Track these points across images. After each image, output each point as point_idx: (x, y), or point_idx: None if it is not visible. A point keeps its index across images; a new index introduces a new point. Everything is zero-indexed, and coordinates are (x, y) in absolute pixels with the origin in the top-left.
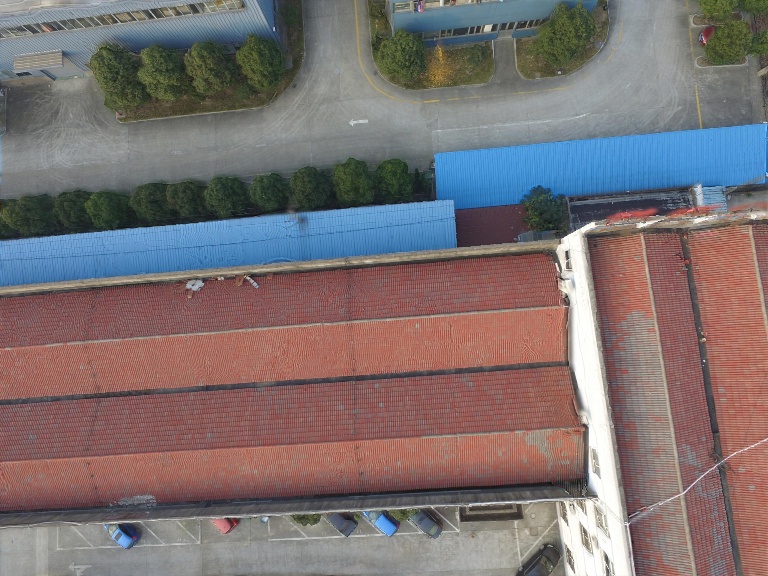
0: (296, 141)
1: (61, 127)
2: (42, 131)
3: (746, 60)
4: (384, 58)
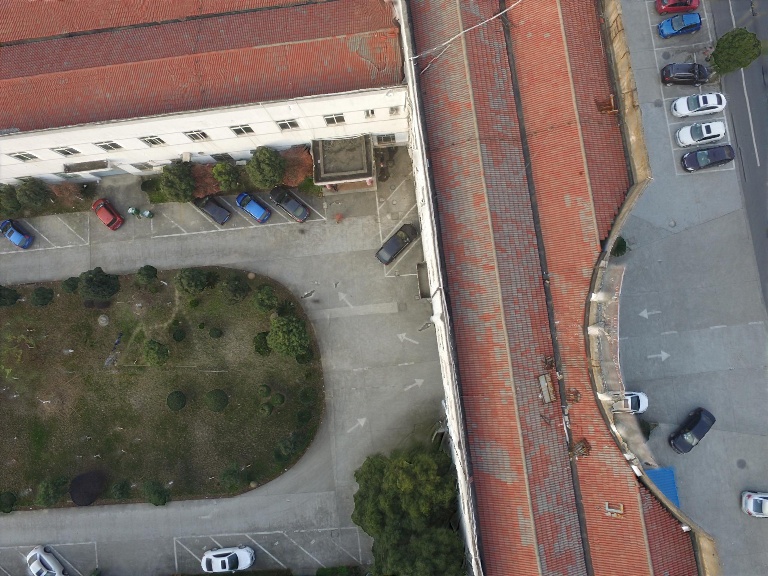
0: None
1: None
2: None
3: None
4: None
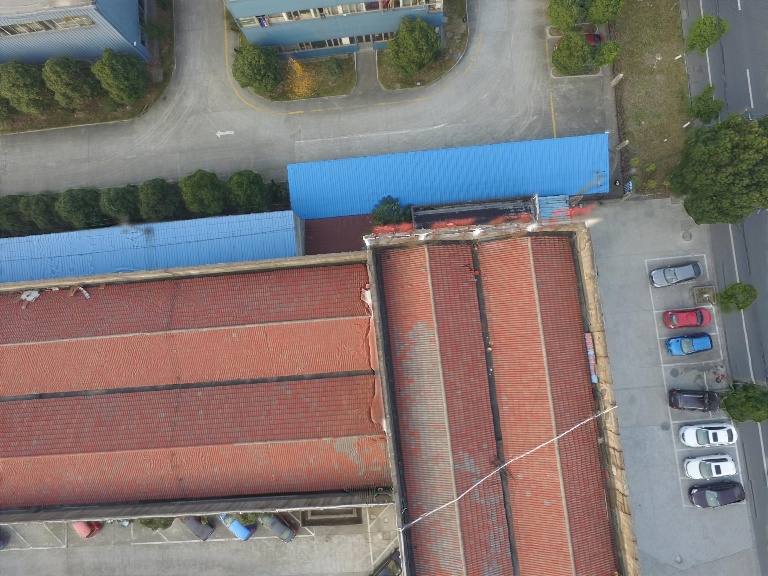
0: (165, 152)
1: None
2: None
3: (600, 70)
4: (237, 71)
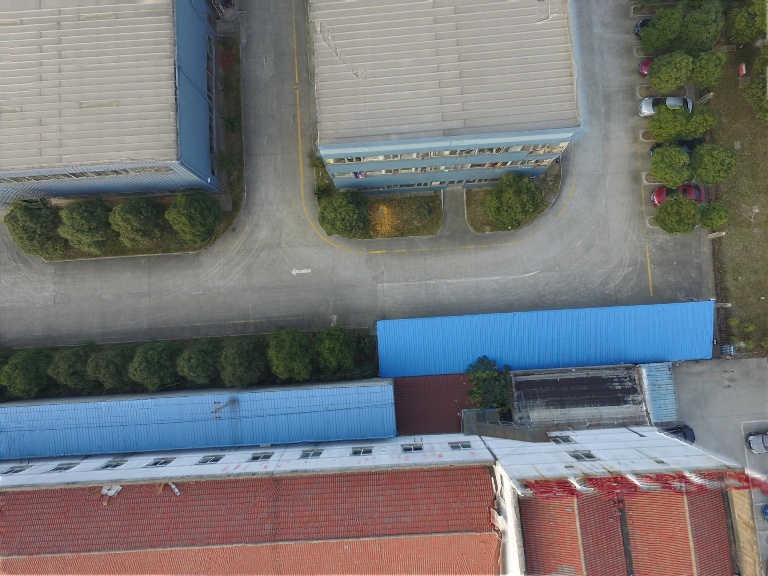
0: (235, 290)
1: None
2: None
3: None
4: (325, 220)
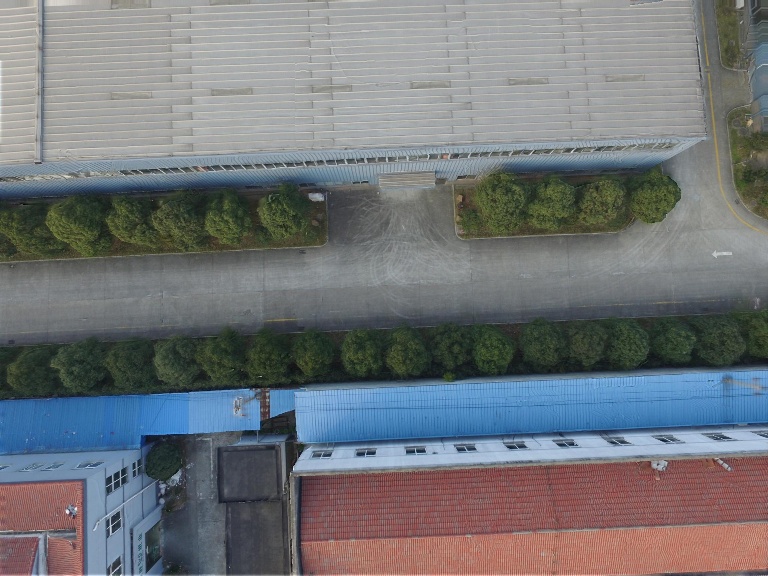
0: (656, 271)
1: (392, 240)
2: (370, 243)
3: None
4: None
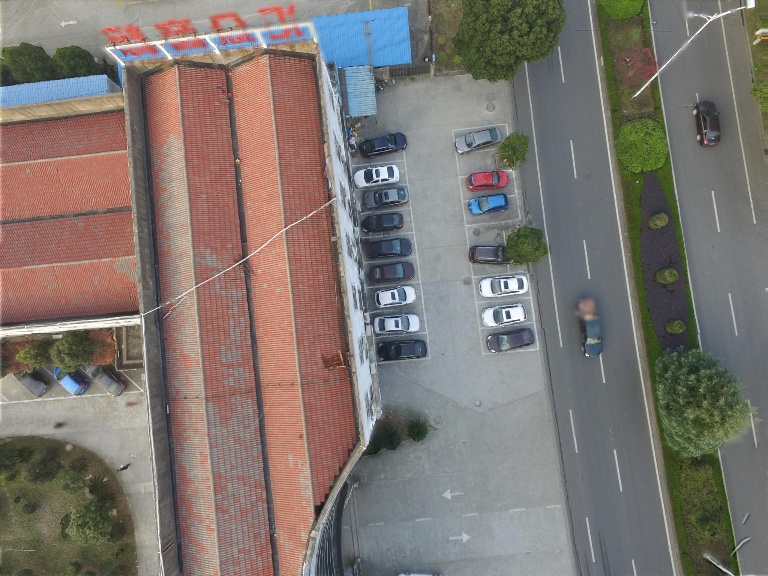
0: (13, 42)
1: None
2: None
3: None
4: None
